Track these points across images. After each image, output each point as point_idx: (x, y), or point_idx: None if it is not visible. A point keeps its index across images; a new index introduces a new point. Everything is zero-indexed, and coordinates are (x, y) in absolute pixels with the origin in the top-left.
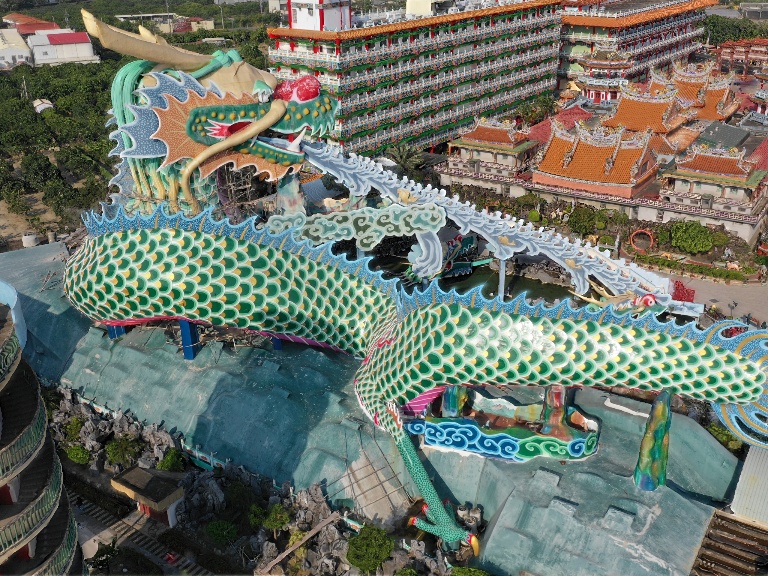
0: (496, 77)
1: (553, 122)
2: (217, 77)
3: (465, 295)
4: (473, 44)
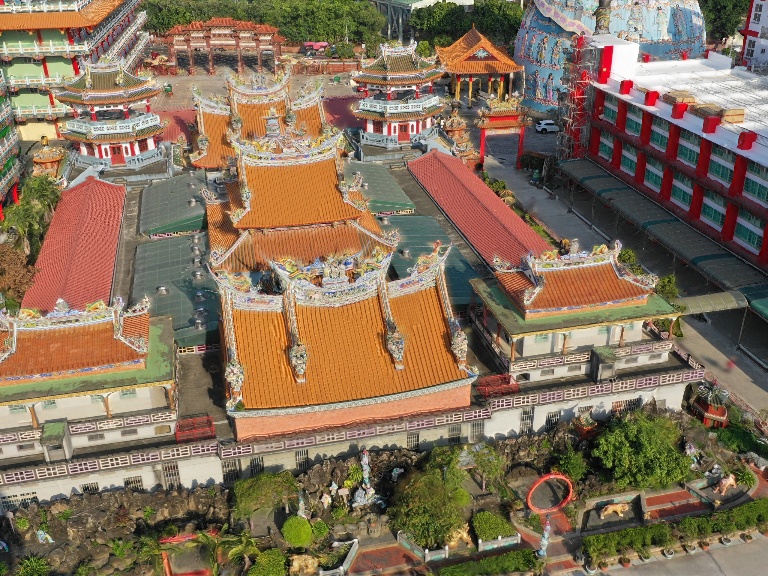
0: None
1: (222, 280)
2: None
3: None
4: None
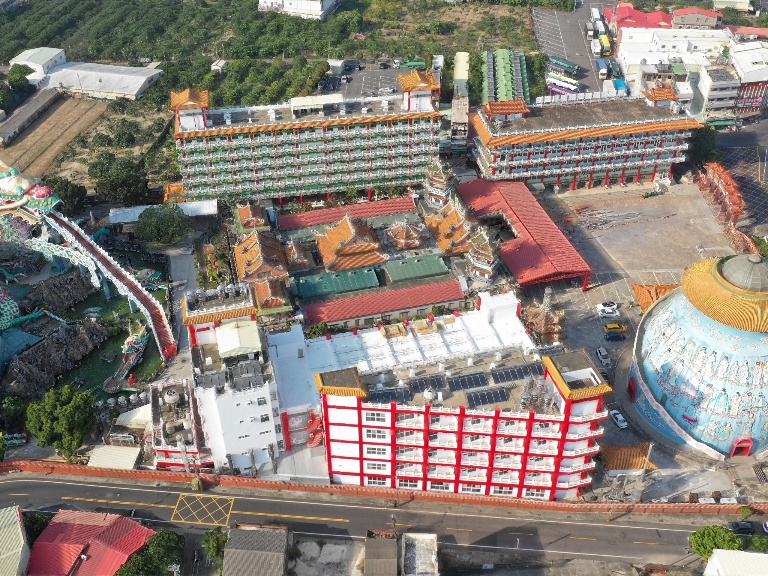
0: (357, 161)
1: None
2: (2, 181)
3: None
4: (319, 142)
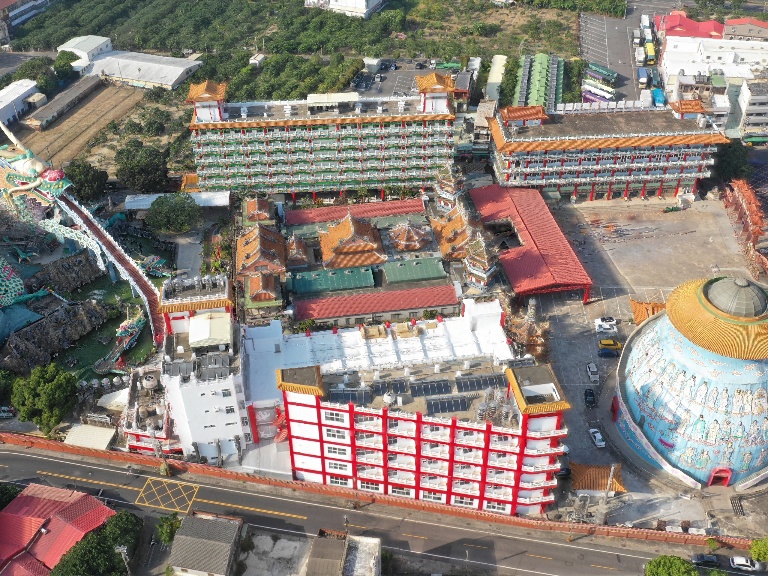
0: (370, 160)
1: None
2: (17, 163)
3: None
4: (331, 139)
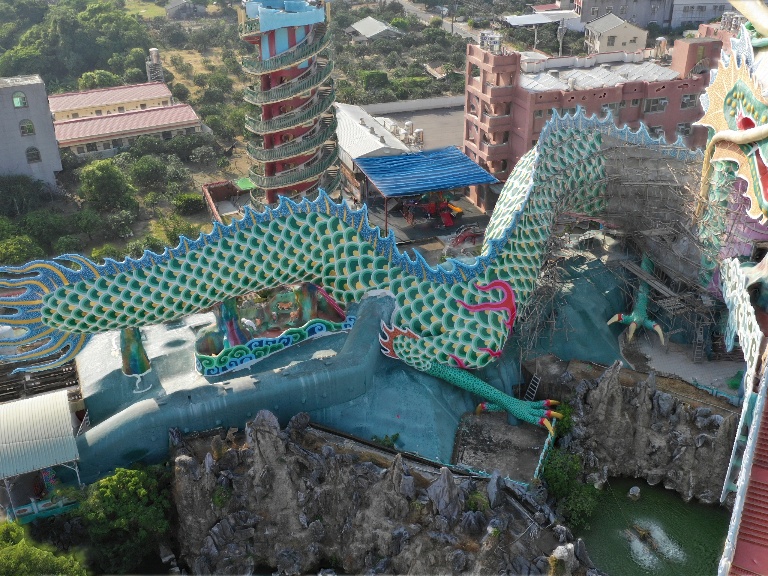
0: None
1: None
2: None
3: (294, 203)
4: None
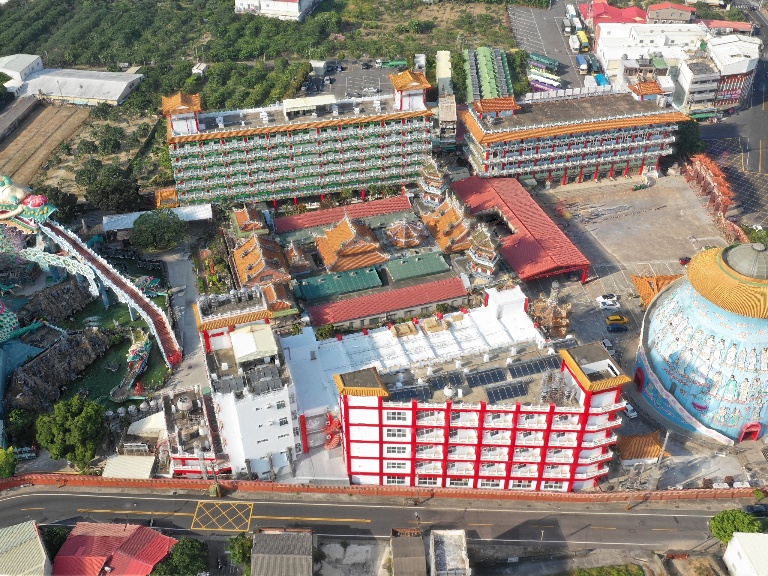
0: (350, 161)
1: None
2: None
3: None
4: (312, 143)
